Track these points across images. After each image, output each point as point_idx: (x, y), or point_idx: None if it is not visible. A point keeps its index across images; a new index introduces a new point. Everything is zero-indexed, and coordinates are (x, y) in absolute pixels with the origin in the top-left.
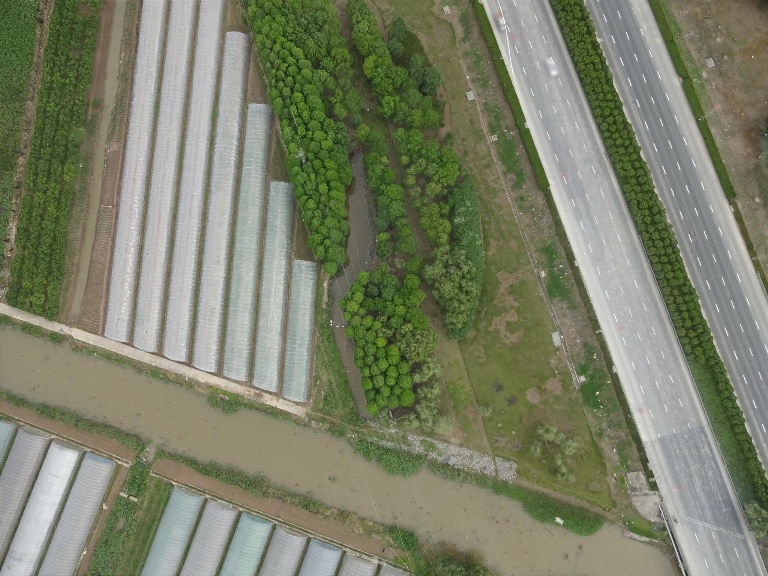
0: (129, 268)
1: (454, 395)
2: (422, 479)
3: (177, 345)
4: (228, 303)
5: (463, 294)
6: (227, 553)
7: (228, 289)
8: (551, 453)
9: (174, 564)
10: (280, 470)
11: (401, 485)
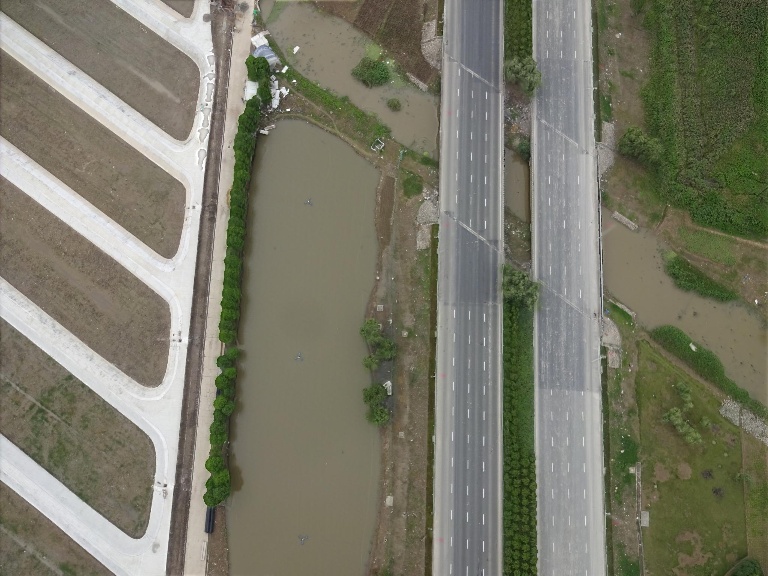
0: None
1: (766, 501)
2: None
3: None
4: None
5: None
6: None
7: None
8: None
9: None
10: None
11: None
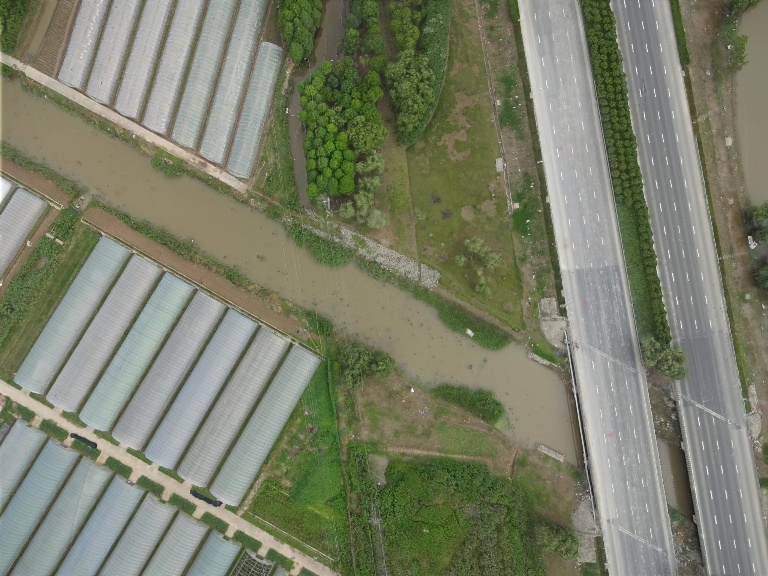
0: (95, 17)
1: (393, 199)
2: (348, 273)
3: (130, 102)
4: (189, 71)
5: (419, 95)
6: (144, 307)
7: (191, 58)
8: (474, 269)
9: (89, 308)
10: (211, 241)
11: (326, 275)
